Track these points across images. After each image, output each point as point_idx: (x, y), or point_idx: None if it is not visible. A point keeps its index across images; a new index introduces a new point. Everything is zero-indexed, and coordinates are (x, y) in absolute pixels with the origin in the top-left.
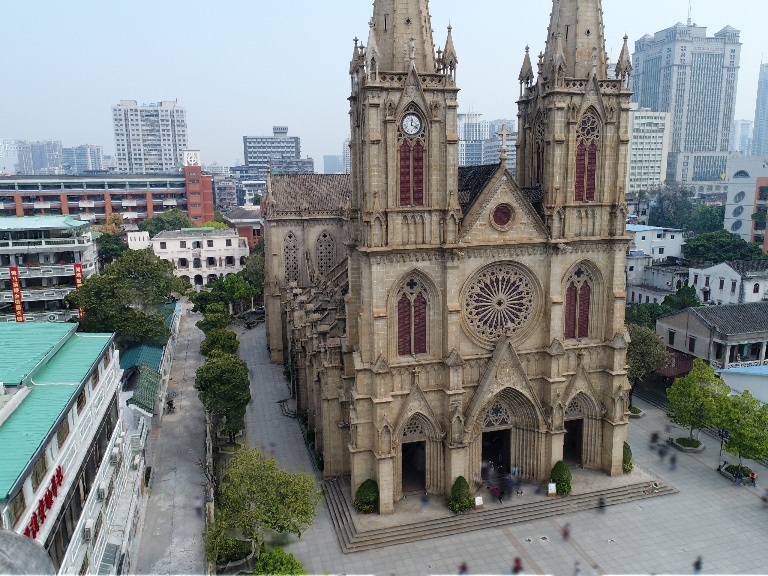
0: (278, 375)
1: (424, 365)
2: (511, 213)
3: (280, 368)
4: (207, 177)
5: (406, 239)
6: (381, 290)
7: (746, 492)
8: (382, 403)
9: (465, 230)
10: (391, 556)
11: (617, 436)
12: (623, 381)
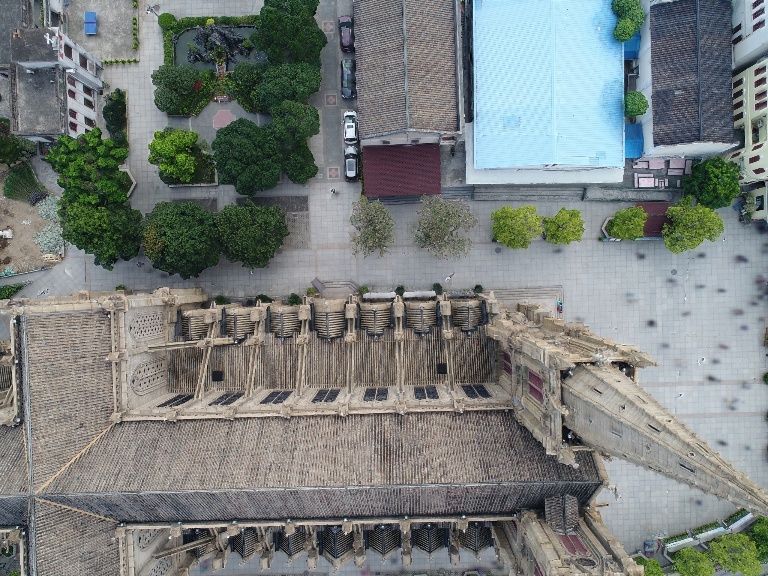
0: None
1: None
2: None
3: None
4: None
5: None
6: None
7: (574, 243)
8: None
9: None
10: None
11: None
12: None
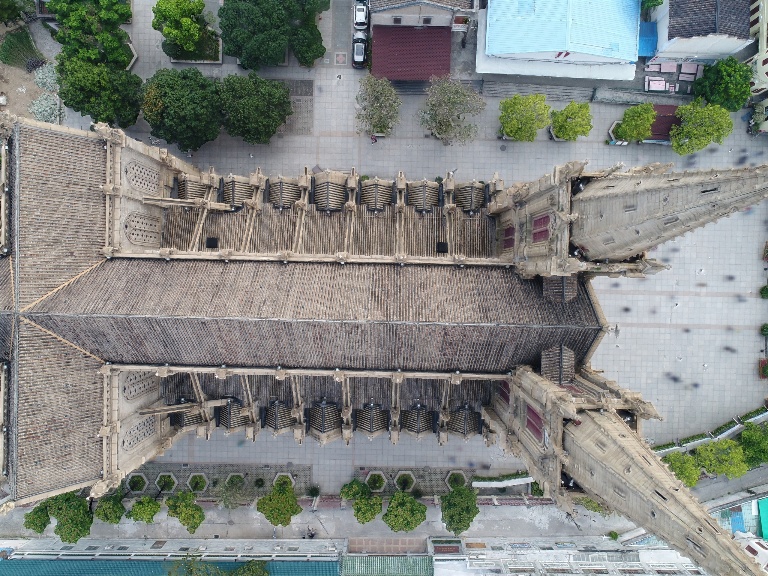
0: None
1: None
2: None
3: None
4: None
5: None
6: None
7: (580, 145)
8: None
9: None
10: None
11: None
12: None
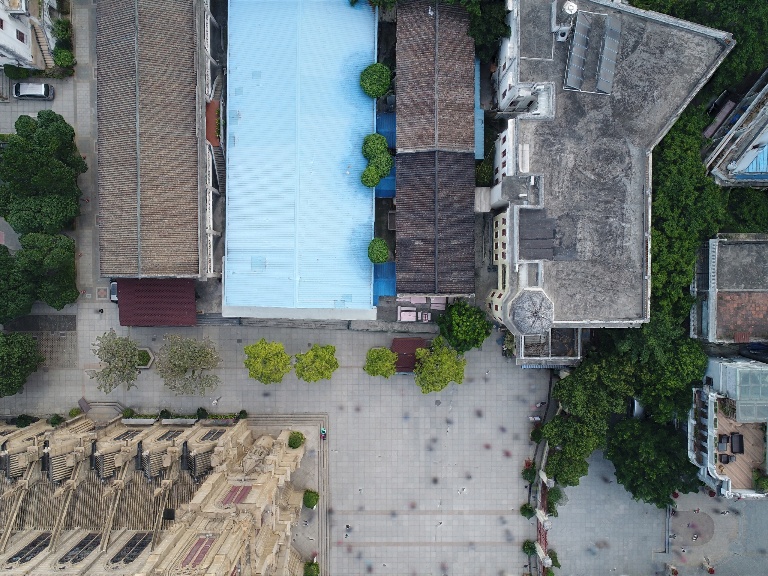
0: None
1: None
2: None
3: None
4: None
5: None
6: None
7: (340, 371)
8: None
9: None
10: None
11: None
12: None
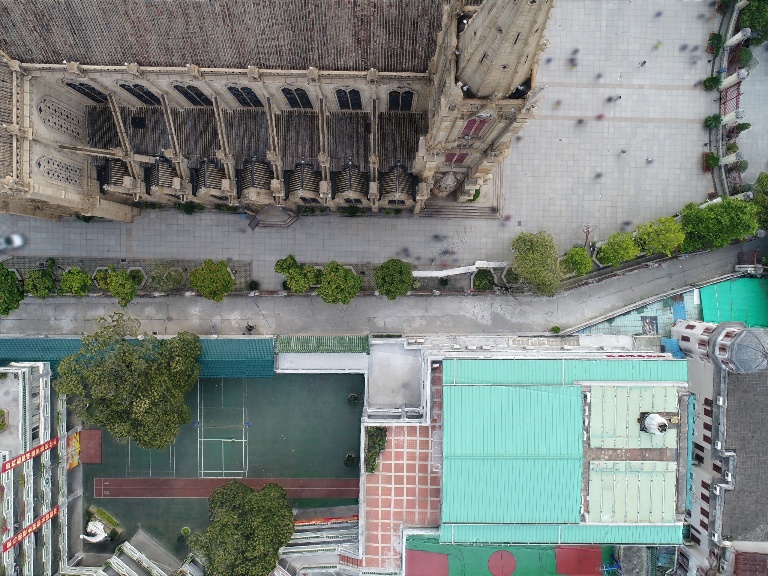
0: (175, 219)
1: None
2: None
3: (151, 214)
4: None
5: None
6: None
7: None
8: None
9: None
10: (511, 192)
11: None
12: None
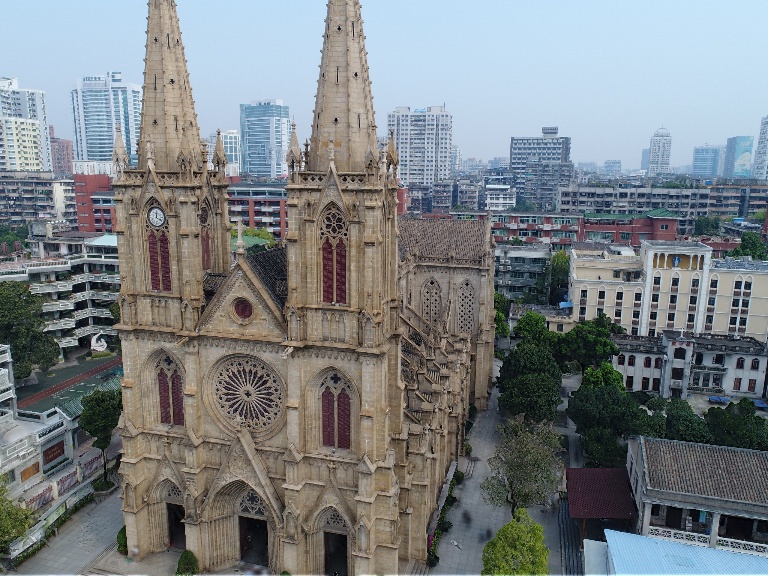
0: None
1: (174, 437)
2: (252, 307)
3: None
4: (400, 189)
5: (157, 320)
6: (130, 363)
7: None
8: (128, 463)
9: (206, 319)
10: None
11: (360, 568)
12: (369, 509)
